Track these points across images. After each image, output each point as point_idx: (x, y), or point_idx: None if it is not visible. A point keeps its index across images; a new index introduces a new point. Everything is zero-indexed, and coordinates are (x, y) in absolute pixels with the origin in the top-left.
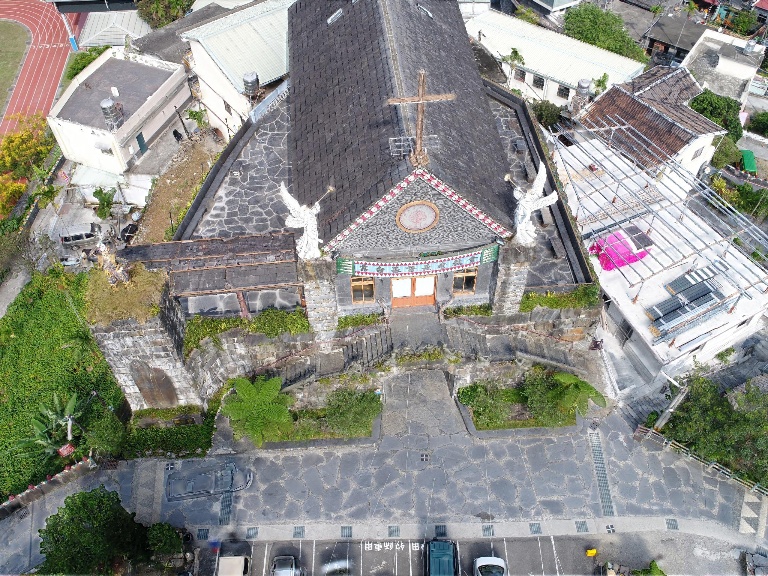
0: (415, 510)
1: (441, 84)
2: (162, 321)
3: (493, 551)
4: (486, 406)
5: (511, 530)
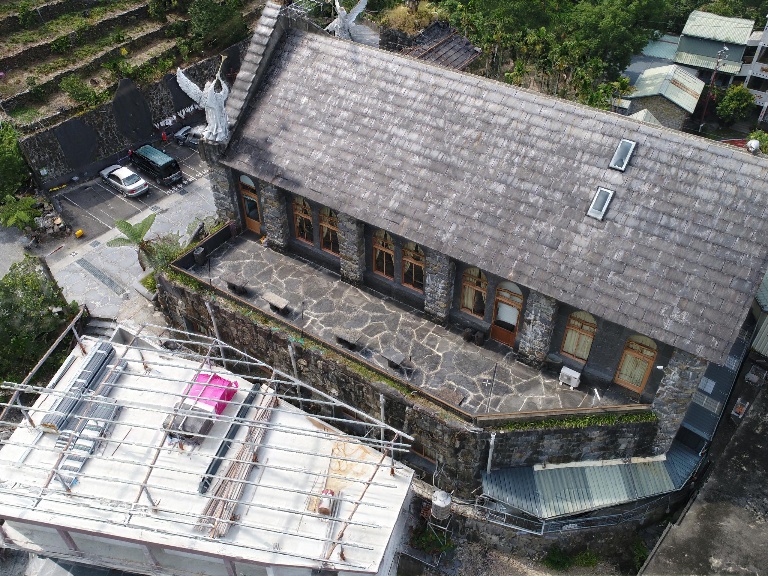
0: (208, 189)
1: (427, 141)
2: (382, 34)
3: (144, 202)
4: (205, 220)
5: (141, 216)
